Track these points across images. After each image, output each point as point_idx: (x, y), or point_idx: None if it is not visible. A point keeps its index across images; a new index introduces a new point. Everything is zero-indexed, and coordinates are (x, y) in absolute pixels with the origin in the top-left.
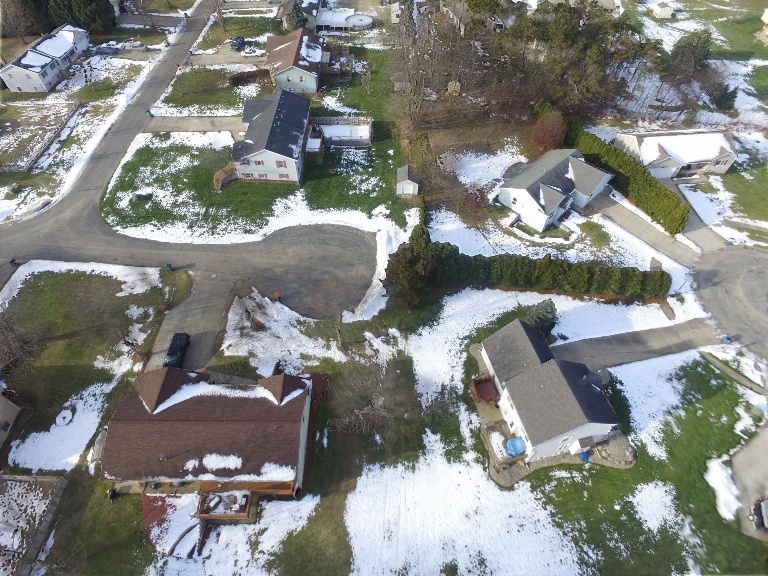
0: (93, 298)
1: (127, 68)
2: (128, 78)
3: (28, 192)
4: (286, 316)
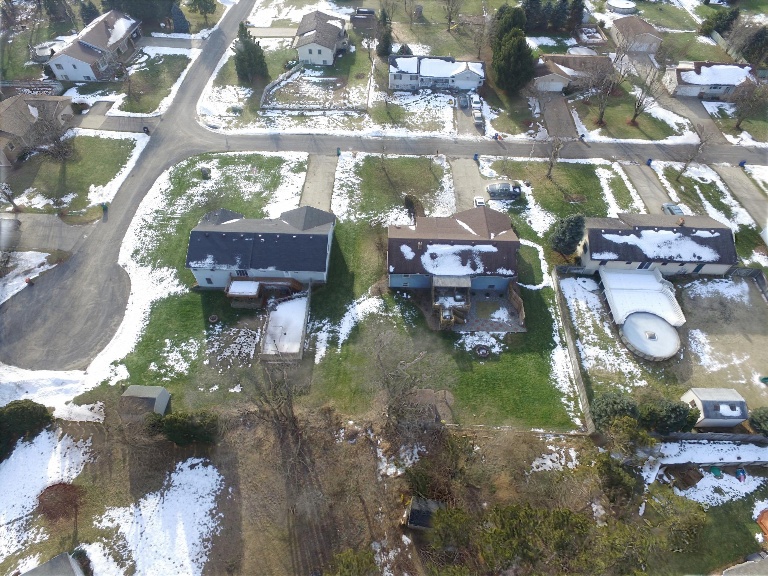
0: (95, 174)
1: (435, 121)
2: (414, 126)
3: (233, 116)
4: (7, 292)
